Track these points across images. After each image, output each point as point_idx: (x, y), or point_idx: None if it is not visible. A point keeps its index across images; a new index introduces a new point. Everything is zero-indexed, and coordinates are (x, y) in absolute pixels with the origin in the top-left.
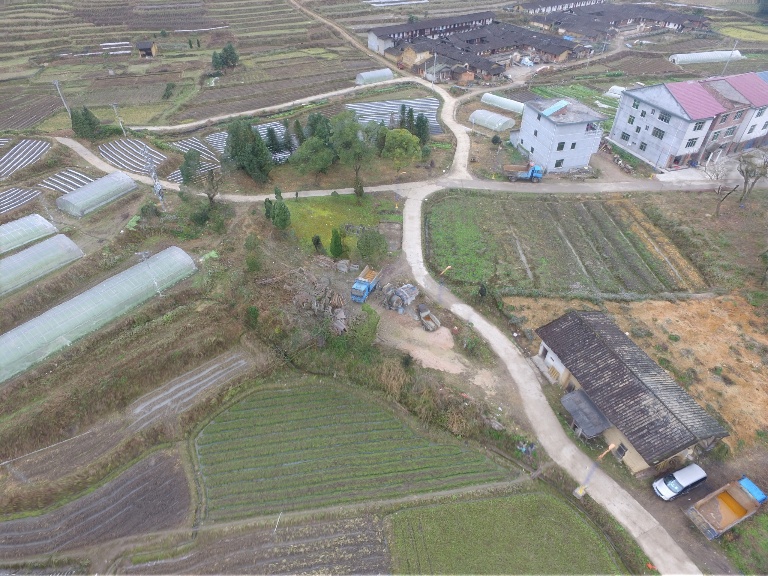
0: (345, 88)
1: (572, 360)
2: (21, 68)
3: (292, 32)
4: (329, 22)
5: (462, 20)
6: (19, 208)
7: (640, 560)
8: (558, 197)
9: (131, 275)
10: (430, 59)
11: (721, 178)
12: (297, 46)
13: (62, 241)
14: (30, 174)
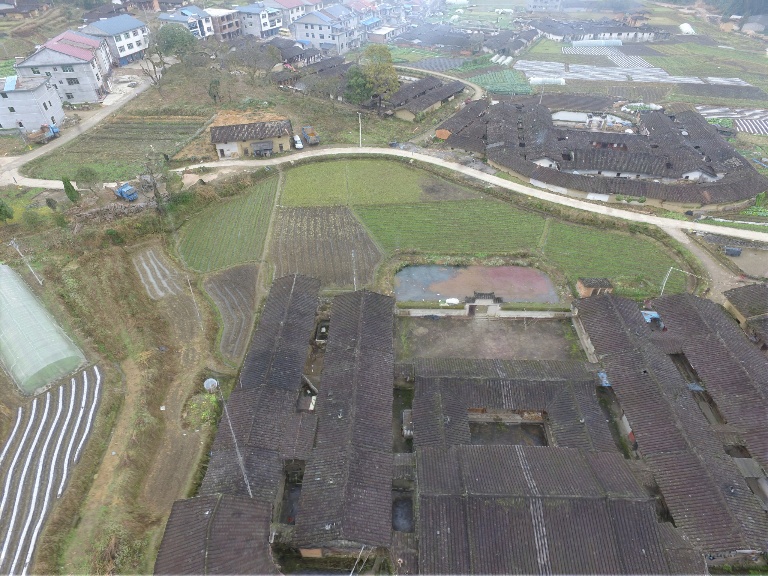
0: None
1: (237, 137)
2: None
3: None
4: None
5: None
6: None
7: (320, 157)
8: (87, 134)
9: None
10: None
11: (127, 92)
12: None
13: None
14: None
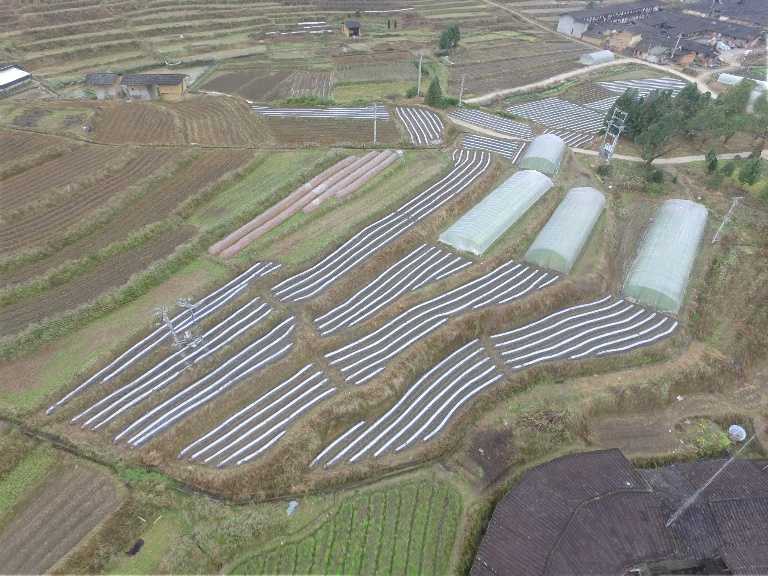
0: (581, 68)
1: None
2: (246, 45)
3: (478, 15)
4: (502, 6)
5: (637, 6)
6: (494, 166)
7: None
8: None
9: (683, 222)
10: (646, 42)
11: None
12: (489, 28)
13: (595, 193)
14: None
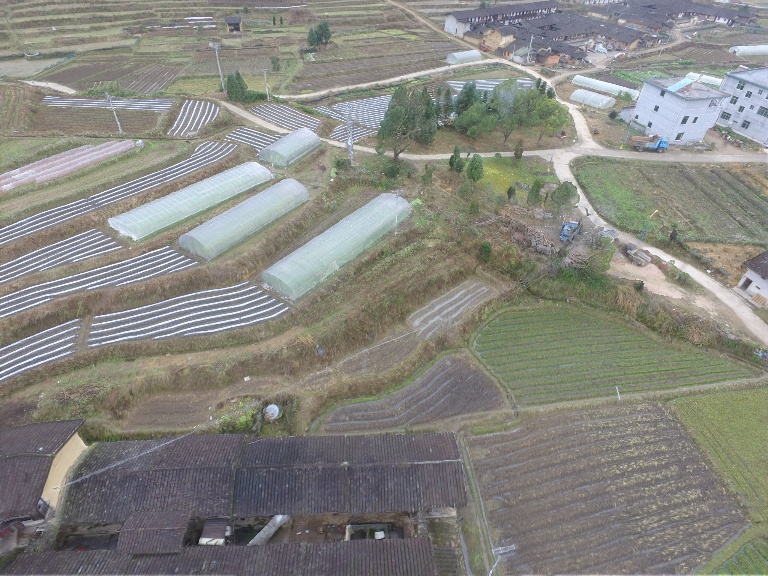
0: (441, 67)
1: None
2: (118, 38)
3: (369, 13)
4: (400, 5)
5: (530, 8)
6: (228, 158)
7: None
8: (686, 165)
9: (368, 214)
10: (515, 42)
11: None
12: (376, 27)
13: (294, 184)
14: (214, 130)
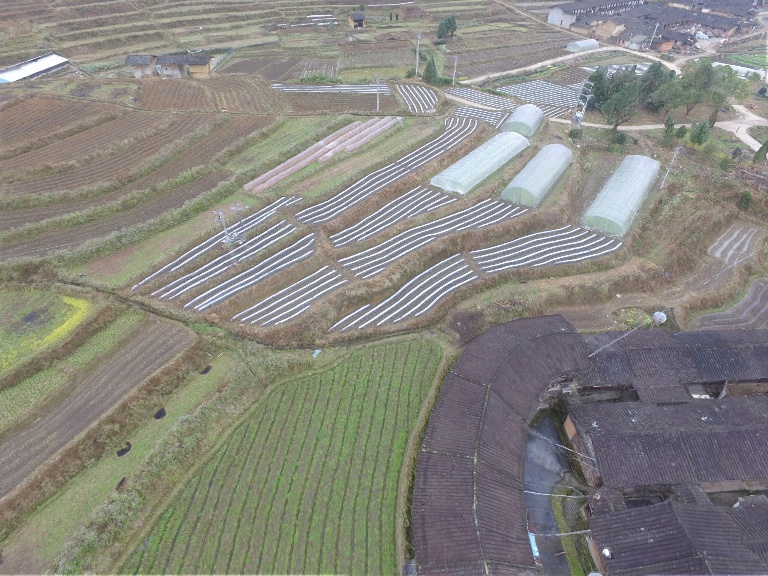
0: (567, 54)
1: None
2: (259, 35)
3: (474, 8)
4: (497, 0)
5: None
6: (479, 130)
7: None
8: None
9: (636, 171)
10: (628, 31)
11: None
12: (484, 20)
13: (563, 148)
14: (442, 108)
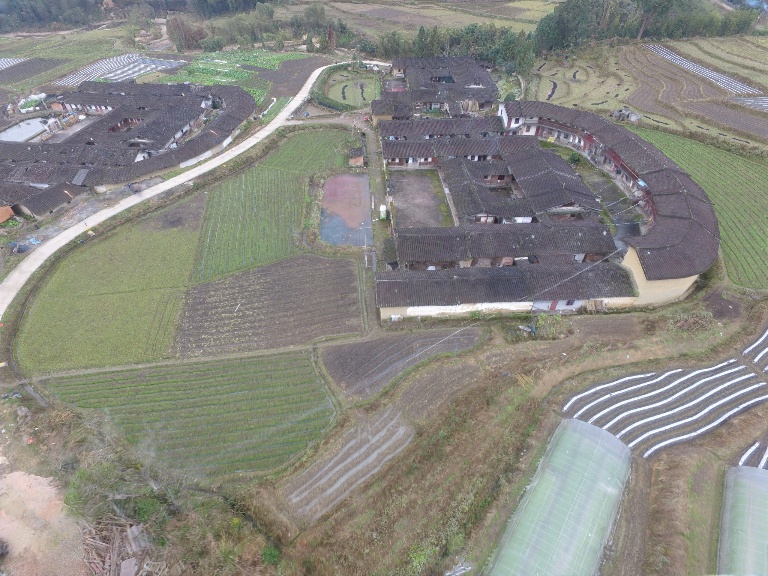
0: None
1: None
2: None
3: None
4: None
5: None
6: None
7: (5, 329)
8: None
9: None
10: None
11: None
12: None
13: None
14: None
